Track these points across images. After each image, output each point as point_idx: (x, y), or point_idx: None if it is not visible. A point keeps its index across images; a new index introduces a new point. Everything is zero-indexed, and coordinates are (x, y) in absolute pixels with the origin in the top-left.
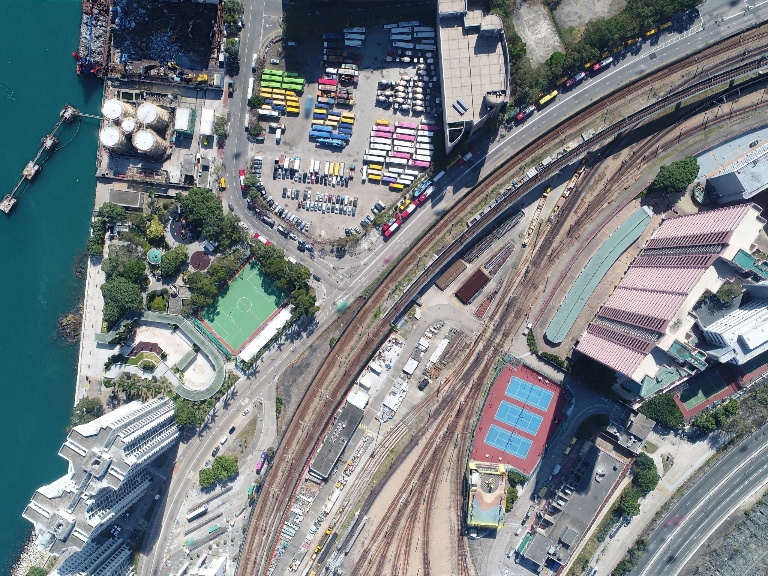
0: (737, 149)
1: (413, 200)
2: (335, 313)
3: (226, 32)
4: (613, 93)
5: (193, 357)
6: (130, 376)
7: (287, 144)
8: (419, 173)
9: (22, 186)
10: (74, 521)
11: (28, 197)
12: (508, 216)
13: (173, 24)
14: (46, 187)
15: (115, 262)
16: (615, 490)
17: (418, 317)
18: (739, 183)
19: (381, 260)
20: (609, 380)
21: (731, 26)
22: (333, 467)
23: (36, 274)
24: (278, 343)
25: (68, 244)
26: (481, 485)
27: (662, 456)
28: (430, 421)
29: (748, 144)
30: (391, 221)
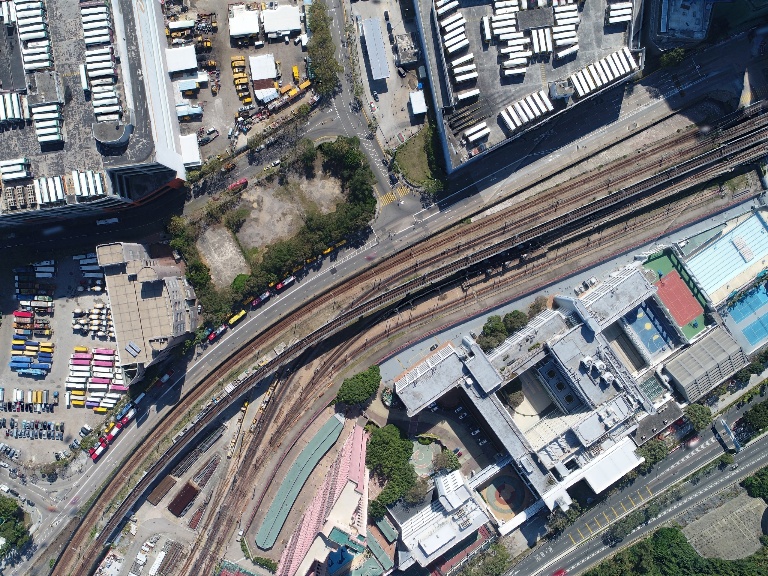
0: (419, 353)
1: (118, 421)
2: (53, 535)
3: None
4: (299, 308)
5: None
6: None
7: None
8: (122, 395)
9: None
10: None
11: None
12: (211, 430)
13: None
14: None
15: None
16: None
17: (134, 533)
18: (403, 402)
19: (93, 481)
20: None
21: (403, 239)
22: None
23: None
24: None
25: None
26: None
27: None
28: None
29: (429, 348)
30: (96, 445)
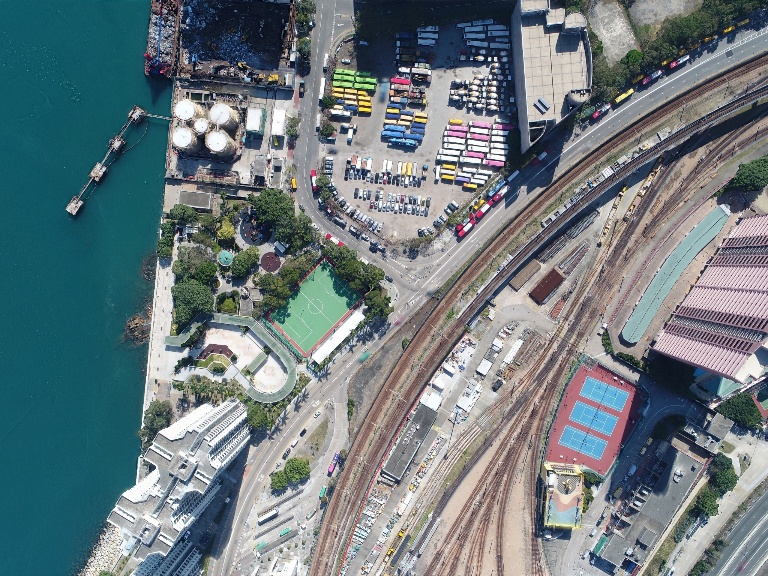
0: None
1: (487, 200)
2: (407, 314)
3: (297, 32)
4: (689, 91)
5: (264, 359)
6: (200, 379)
7: (359, 144)
8: (493, 173)
9: (89, 188)
10: (160, 526)
11: (95, 199)
12: (583, 215)
13: (243, 24)
14: (113, 189)
15: (186, 264)
16: (691, 490)
17: (492, 318)
18: None
19: (454, 260)
20: (688, 380)
21: None
22: (406, 469)
23: (103, 276)
24: (350, 345)
25: (136, 246)
26: (558, 486)
27: (739, 456)
28: (504, 422)
29: None
30: (465, 221)
